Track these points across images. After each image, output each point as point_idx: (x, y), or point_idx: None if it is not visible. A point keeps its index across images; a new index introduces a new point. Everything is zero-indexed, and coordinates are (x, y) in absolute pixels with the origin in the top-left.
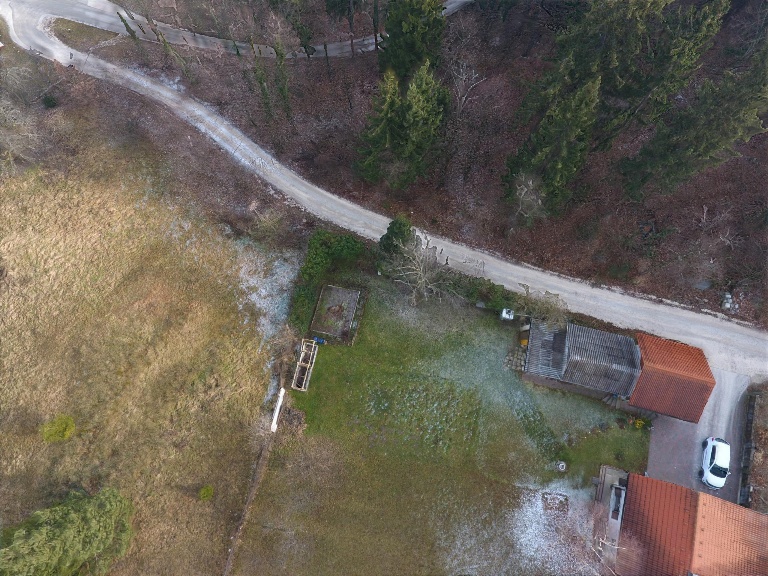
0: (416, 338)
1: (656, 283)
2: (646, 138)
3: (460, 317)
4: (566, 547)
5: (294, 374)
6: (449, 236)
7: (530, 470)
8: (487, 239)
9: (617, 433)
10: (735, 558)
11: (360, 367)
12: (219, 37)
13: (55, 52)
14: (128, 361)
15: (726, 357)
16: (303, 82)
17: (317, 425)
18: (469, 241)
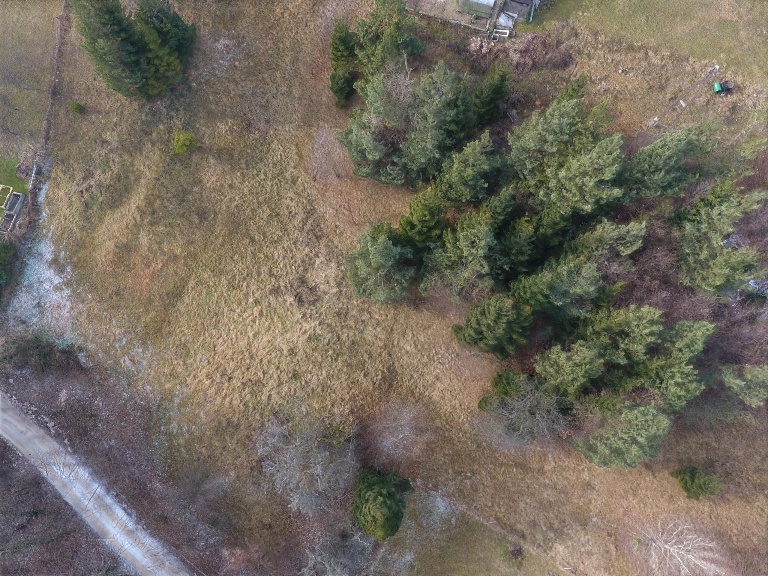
0: None
1: None
2: None
3: None
4: None
5: None
6: None
7: None
8: None
9: None
10: None
11: None
12: None
13: None
14: (153, 207)
15: None
16: None
17: (8, 167)
18: None
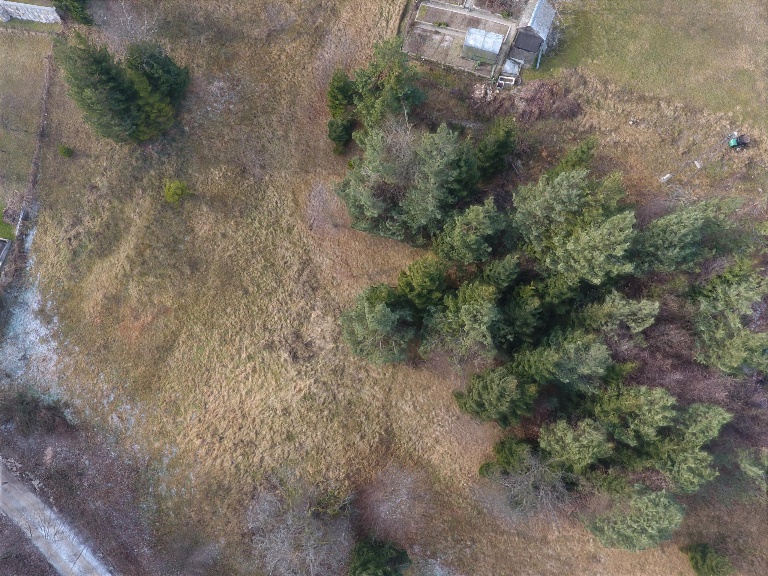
0: None
1: None
2: None
3: None
4: None
5: None
6: None
7: None
8: None
9: None
10: None
11: None
12: None
13: None
14: (143, 257)
15: None
16: None
17: None
18: None
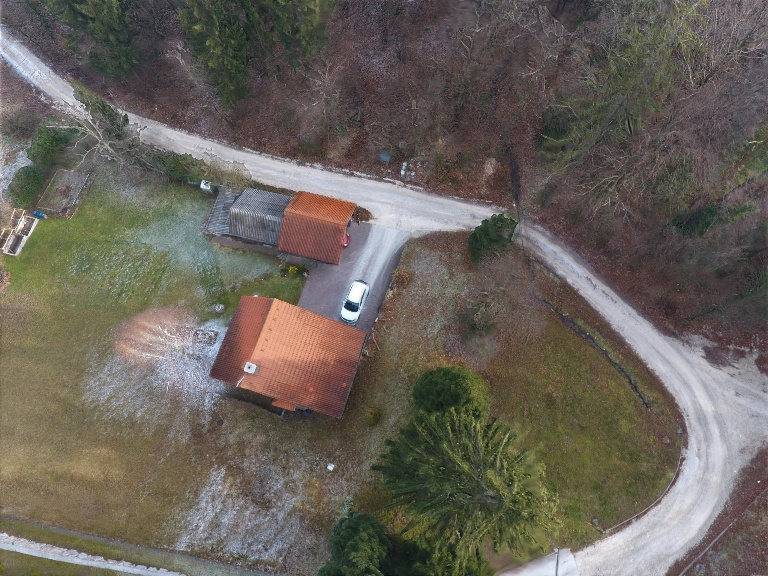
0: (130, 212)
1: (350, 158)
2: (377, 38)
3: (172, 193)
4: (201, 371)
5: None
6: (186, 128)
7: (192, 312)
8: (219, 130)
9: (277, 280)
10: (307, 358)
11: (73, 236)
12: None
13: None
14: None
15: (394, 217)
16: None
17: (20, 283)
18: (203, 132)
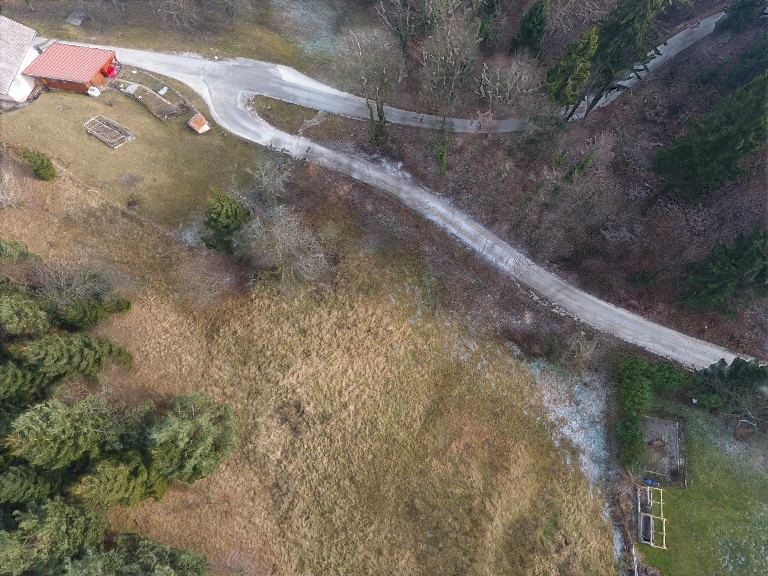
0: (753, 478)
1: None
2: None
3: None
4: None
5: (650, 530)
6: (751, 354)
7: None
8: None
9: None
10: None
11: (702, 513)
12: (419, 112)
13: (263, 135)
14: (471, 518)
15: None
16: (519, 163)
17: None
18: None
